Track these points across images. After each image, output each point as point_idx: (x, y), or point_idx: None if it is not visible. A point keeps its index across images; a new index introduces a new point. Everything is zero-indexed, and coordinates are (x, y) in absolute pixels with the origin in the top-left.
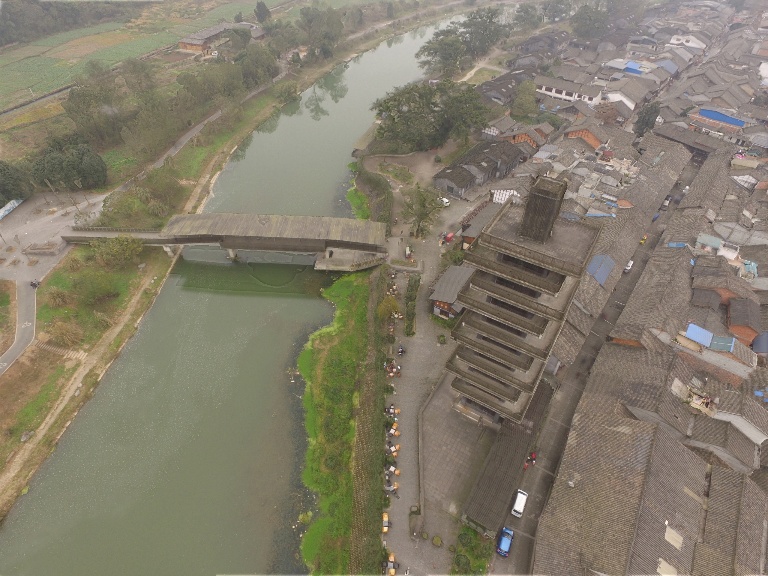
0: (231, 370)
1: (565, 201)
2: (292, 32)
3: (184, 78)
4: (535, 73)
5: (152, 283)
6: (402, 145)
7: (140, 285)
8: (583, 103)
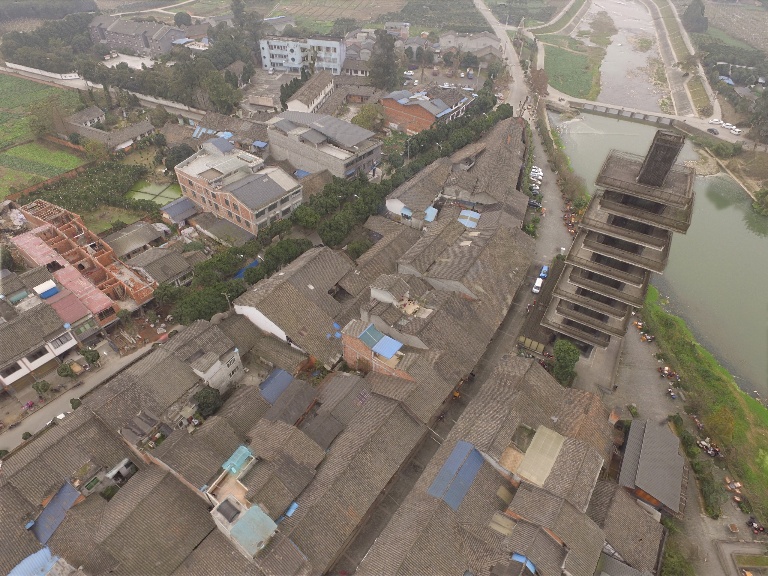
0: None
1: None
2: None
3: None
4: None
5: None
6: None
7: None
8: None
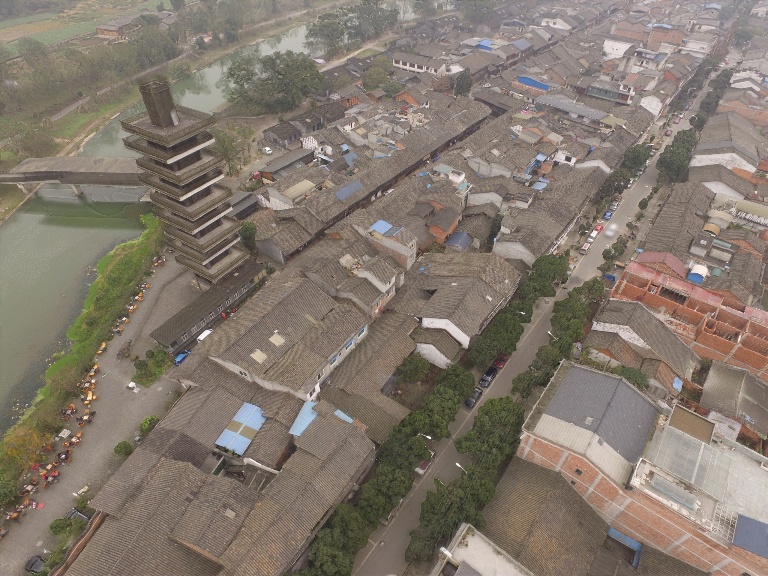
0: (42, 268)
1: (360, 146)
2: (200, 18)
3: (71, 54)
4: (399, 50)
5: (2, 212)
6: (251, 108)
7: None
8: (428, 74)
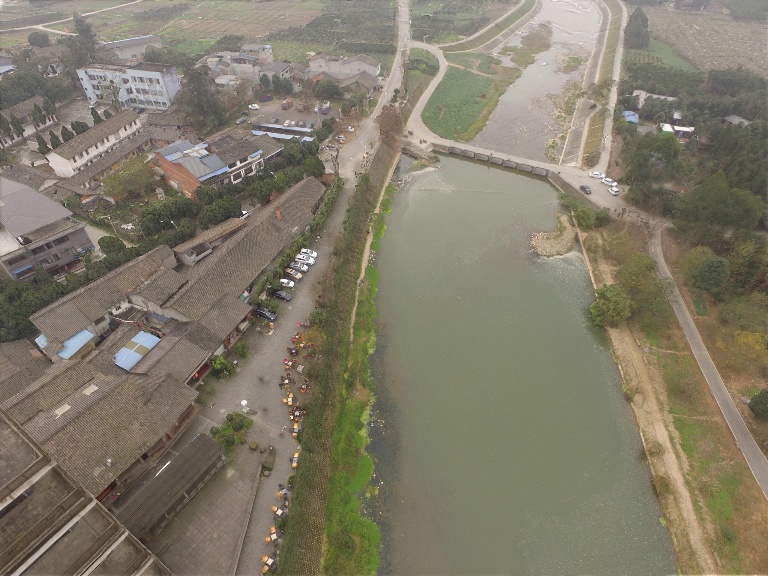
0: None
1: None
2: None
3: None
4: None
5: None
6: None
7: None
8: None
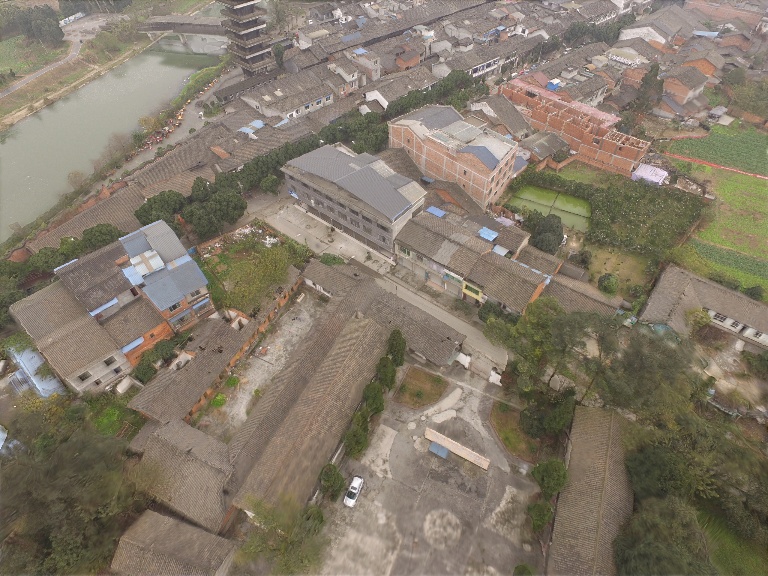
0: (159, 76)
1: None
2: None
3: None
4: None
5: (138, 49)
6: None
7: (132, 49)
8: None
